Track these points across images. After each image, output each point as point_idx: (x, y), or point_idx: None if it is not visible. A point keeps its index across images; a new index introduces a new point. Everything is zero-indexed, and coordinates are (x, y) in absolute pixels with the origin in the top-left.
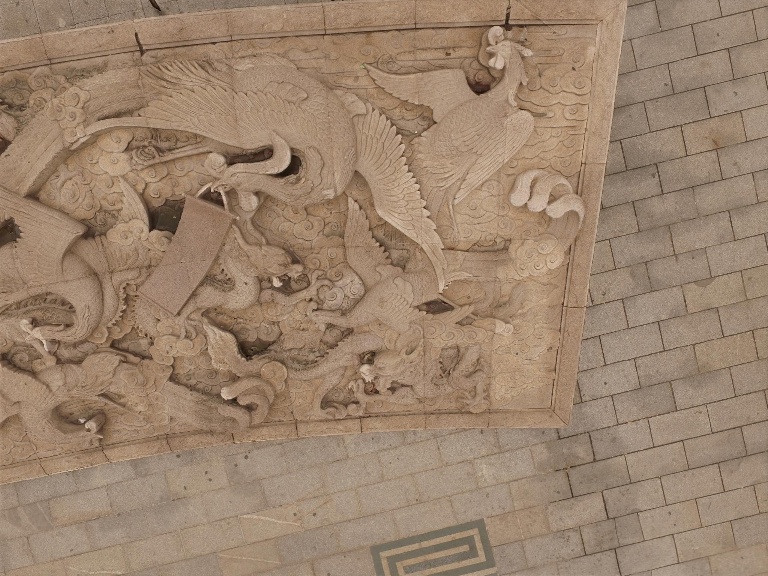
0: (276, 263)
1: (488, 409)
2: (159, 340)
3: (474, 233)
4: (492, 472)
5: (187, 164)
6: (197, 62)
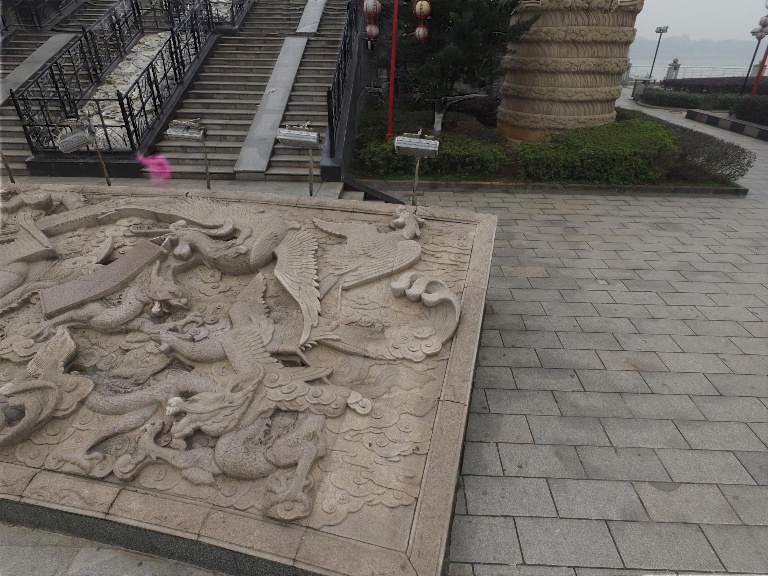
0: (168, 291)
1: (306, 526)
2: (8, 337)
3: (355, 315)
4: None
5: None
6: (211, 199)
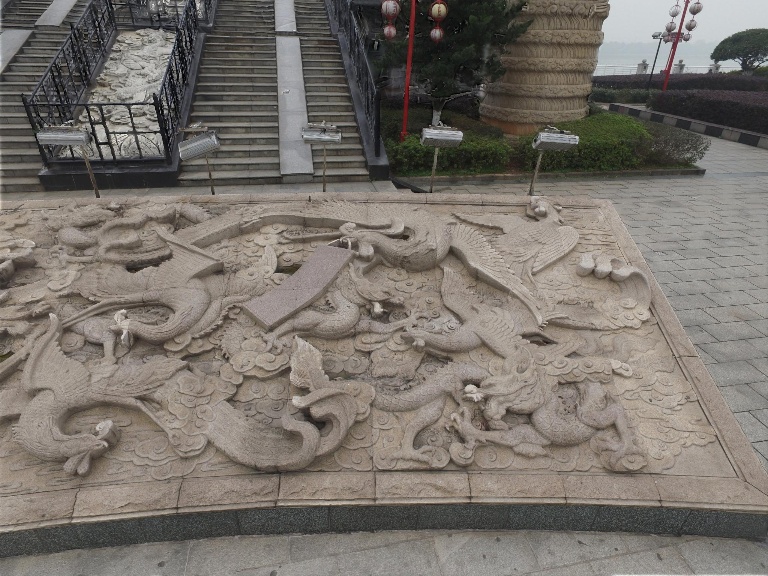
0: (381, 291)
1: (648, 473)
2: (239, 355)
3: (557, 295)
4: None
5: None
6: None
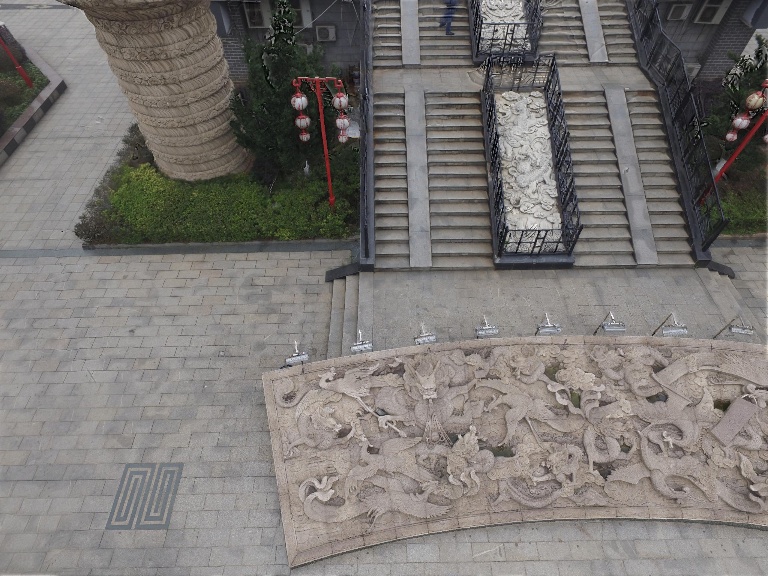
0: None
1: None
2: (714, 456)
3: None
4: None
5: (728, 387)
6: None
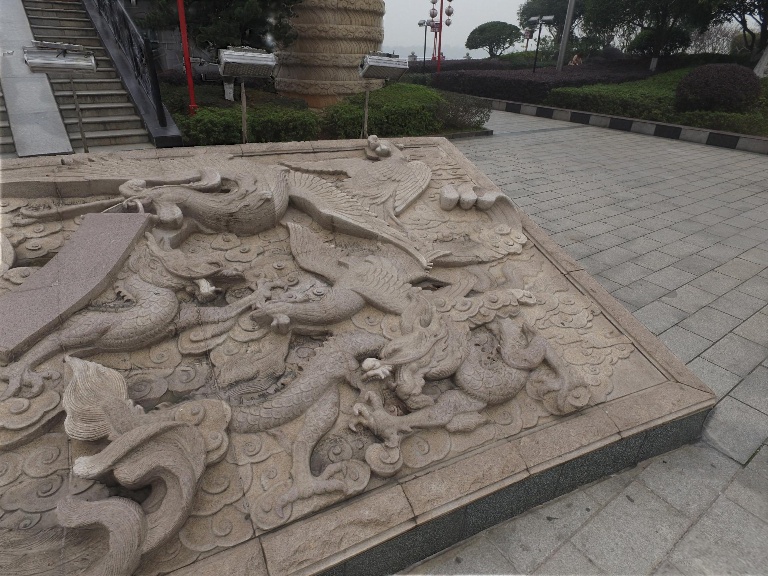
0: (205, 263)
1: (594, 405)
2: None
3: (429, 234)
4: (723, 569)
5: None
6: None
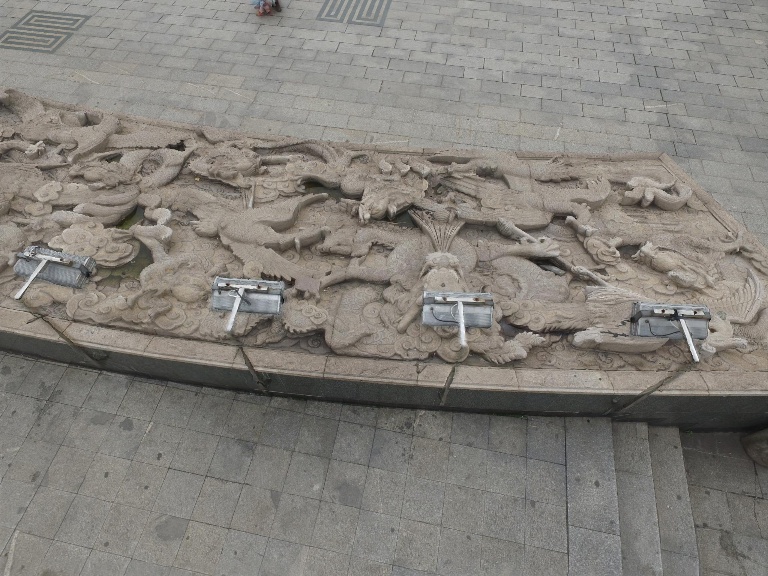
0: None
1: None
2: None
3: None
4: None
5: None
6: None
